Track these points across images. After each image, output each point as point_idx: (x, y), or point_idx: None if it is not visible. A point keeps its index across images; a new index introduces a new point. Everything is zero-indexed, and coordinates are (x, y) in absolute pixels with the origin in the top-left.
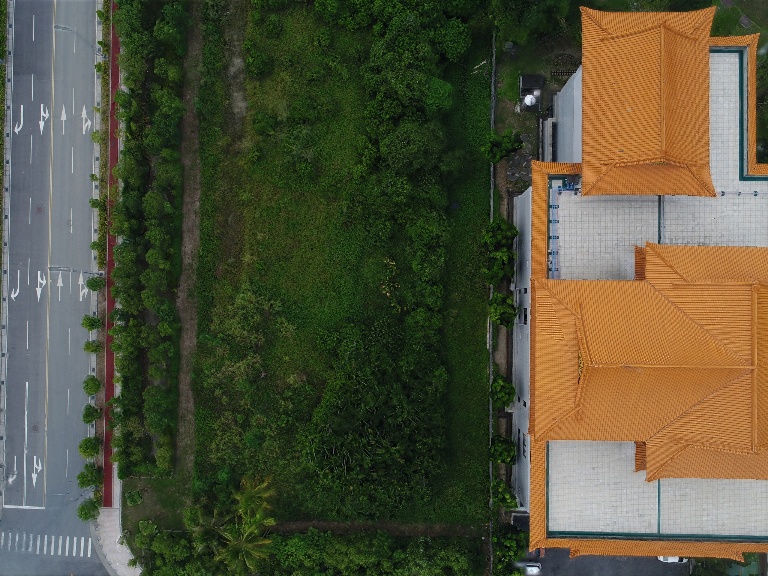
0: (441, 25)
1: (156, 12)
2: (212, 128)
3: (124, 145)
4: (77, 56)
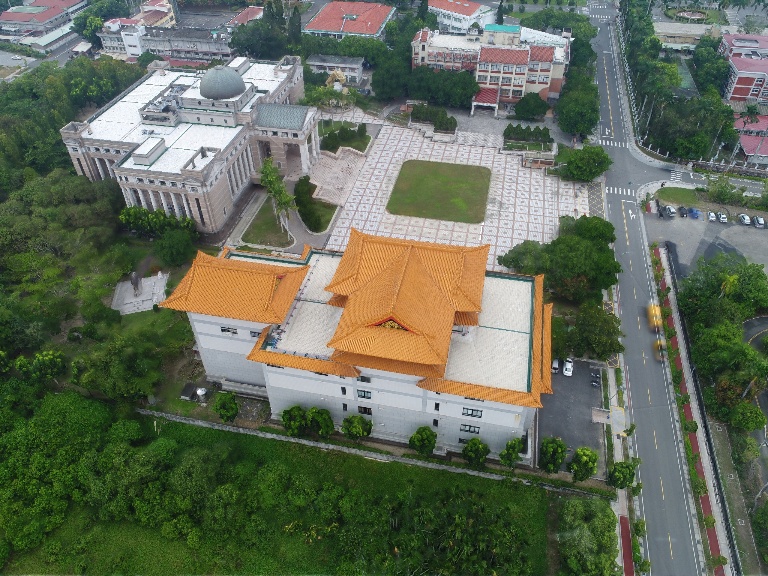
0: (108, 437)
1: None
2: None
3: None
4: None
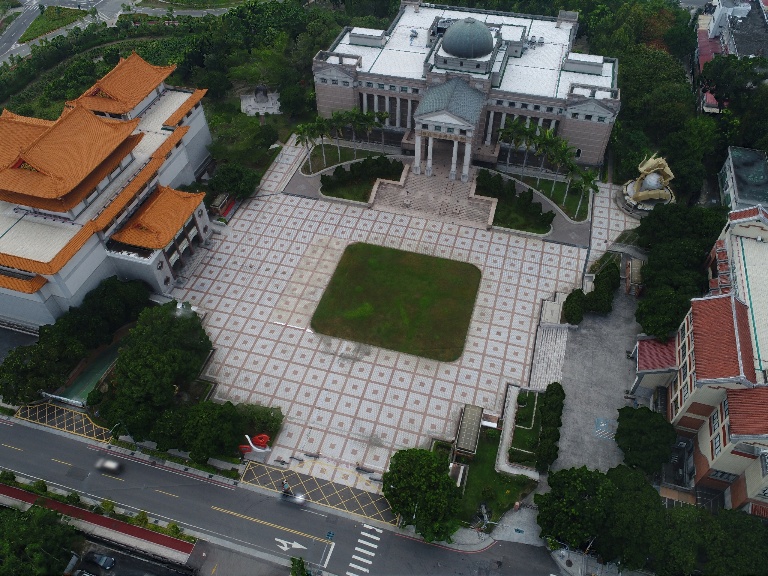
0: None
1: None
2: None
3: None
4: None
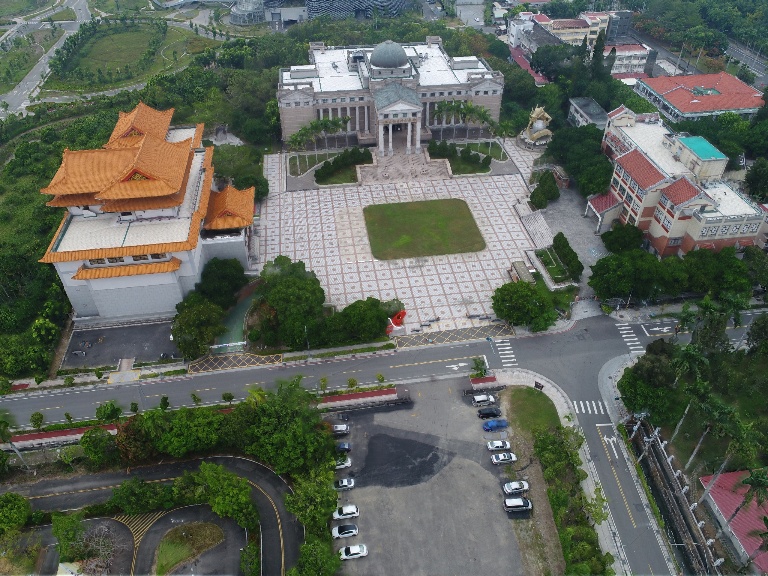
0: None
1: None
2: None
3: None
4: None
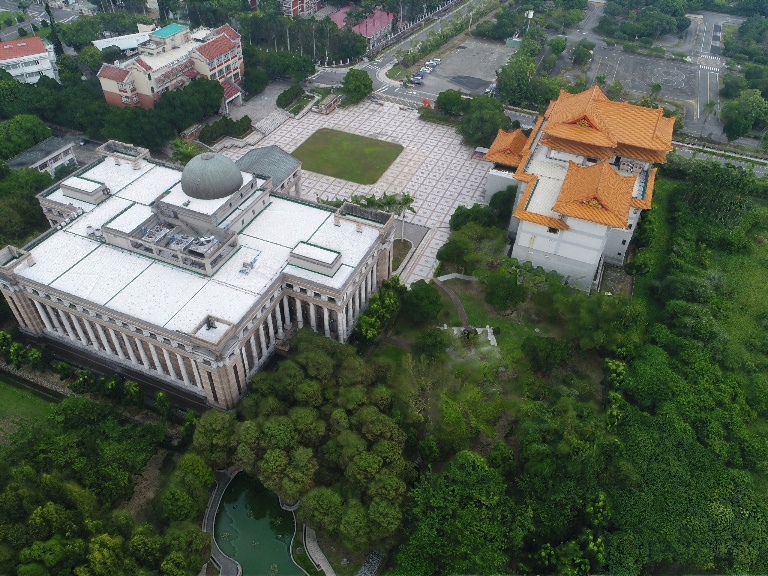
0: None
1: None
2: None
3: None
4: None
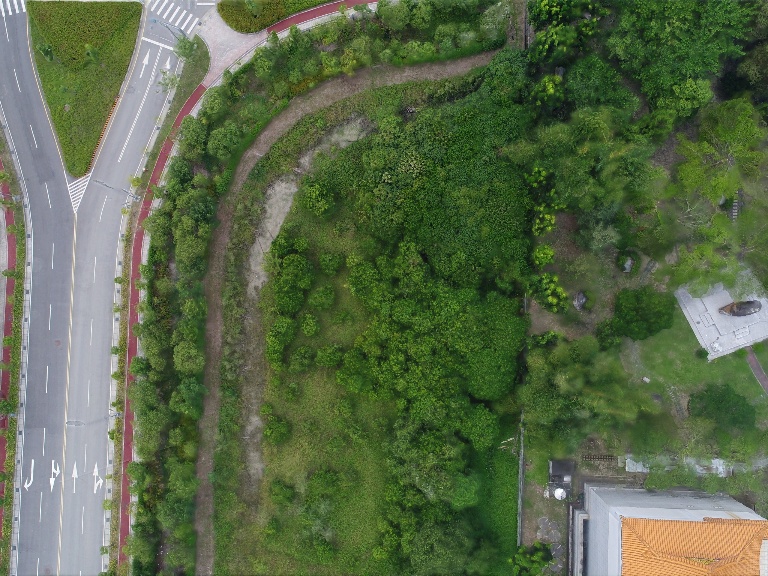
0: (468, 417)
1: (172, 365)
2: (227, 493)
3: (136, 518)
4: (90, 411)
